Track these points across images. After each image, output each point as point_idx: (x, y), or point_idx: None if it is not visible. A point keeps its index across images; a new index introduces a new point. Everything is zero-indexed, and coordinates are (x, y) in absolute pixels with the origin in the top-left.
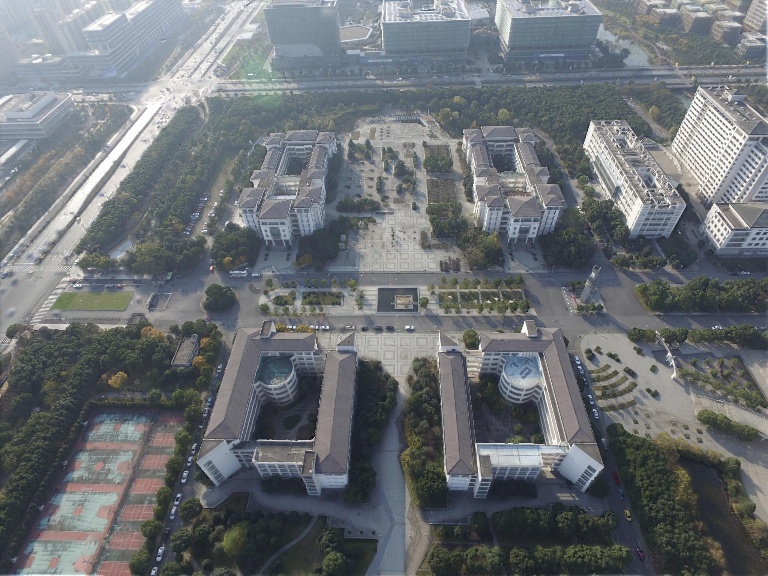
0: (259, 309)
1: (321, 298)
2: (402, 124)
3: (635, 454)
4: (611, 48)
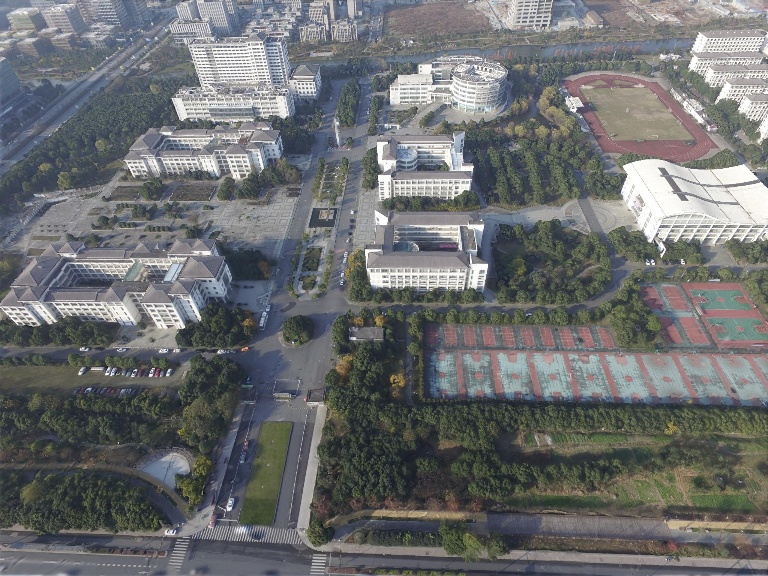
0: (317, 298)
1: (312, 259)
2: (45, 216)
3: None
4: (29, 85)
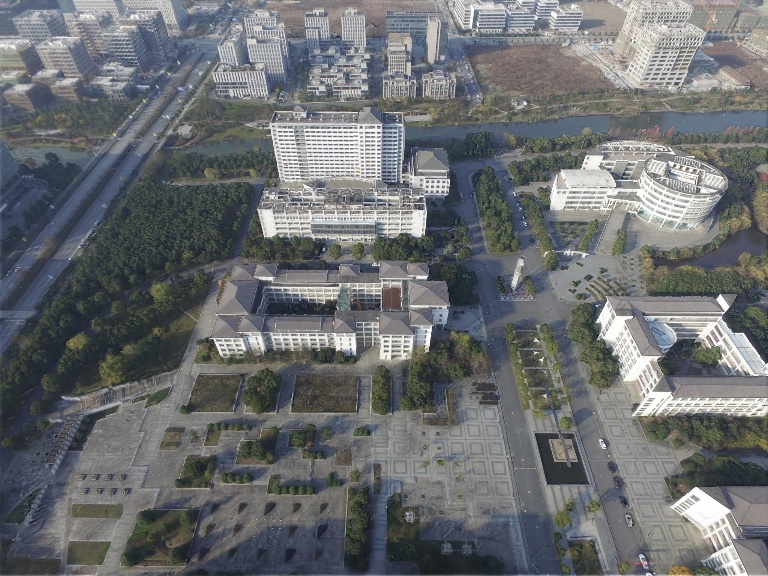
0: None
1: (591, 575)
2: (86, 449)
3: (684, 286)
4: (28, 164)
